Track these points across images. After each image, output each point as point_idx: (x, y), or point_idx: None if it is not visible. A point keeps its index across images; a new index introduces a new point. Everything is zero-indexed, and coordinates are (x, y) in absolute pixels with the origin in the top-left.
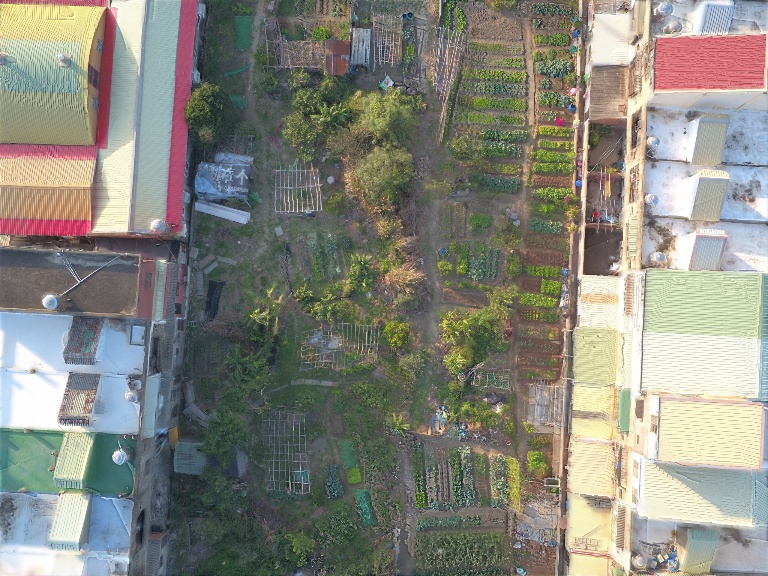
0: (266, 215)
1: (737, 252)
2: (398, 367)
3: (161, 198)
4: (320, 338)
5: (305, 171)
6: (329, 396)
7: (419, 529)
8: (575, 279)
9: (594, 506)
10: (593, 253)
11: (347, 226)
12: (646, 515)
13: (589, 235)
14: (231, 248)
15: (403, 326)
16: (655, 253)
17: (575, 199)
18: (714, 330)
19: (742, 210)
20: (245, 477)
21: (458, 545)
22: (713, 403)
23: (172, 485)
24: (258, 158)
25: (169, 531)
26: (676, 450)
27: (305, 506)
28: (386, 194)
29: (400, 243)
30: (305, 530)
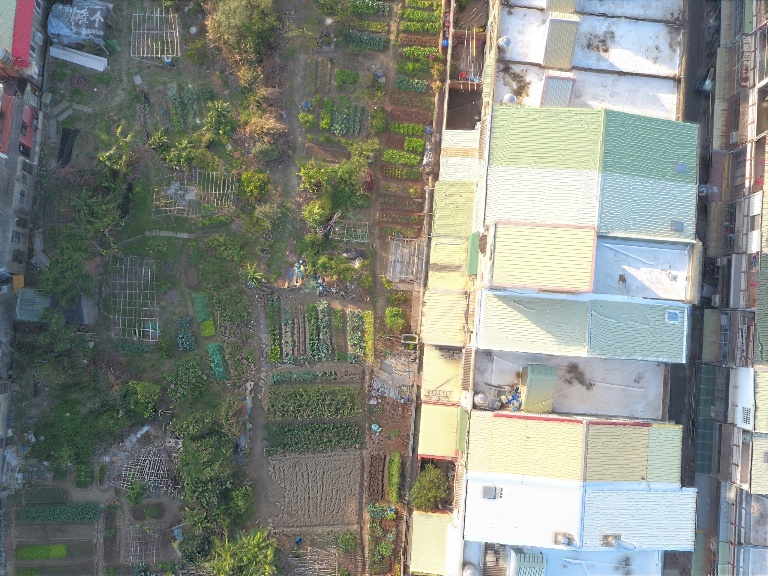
0: (125, 63)
1: (589, 101)
2: (254, 217)
3: (6, 31)
4: (177, 189)
5: (163, 16)
6: (185, 248)
7: (273, 383)
8: (439, 139)
9: (448, 358)
10: (459, 114)
11: (208, 77)
12: (484, 346)
13: (455, 96)
14: (87, 95)
15: (261, 176)
16: (505, 95)
17: (440, 57)
18: (552, 159)
19: (595, 60)
20: (94, 328)
21: (311, 398)
22: (547, 228)
23: (16, 334)
24: (118, 5)
25: (11, 381)
26: (511, 275)
27: (156, 358)
28: (246, 42)
29: (260, 93)
30: (154, 381)
